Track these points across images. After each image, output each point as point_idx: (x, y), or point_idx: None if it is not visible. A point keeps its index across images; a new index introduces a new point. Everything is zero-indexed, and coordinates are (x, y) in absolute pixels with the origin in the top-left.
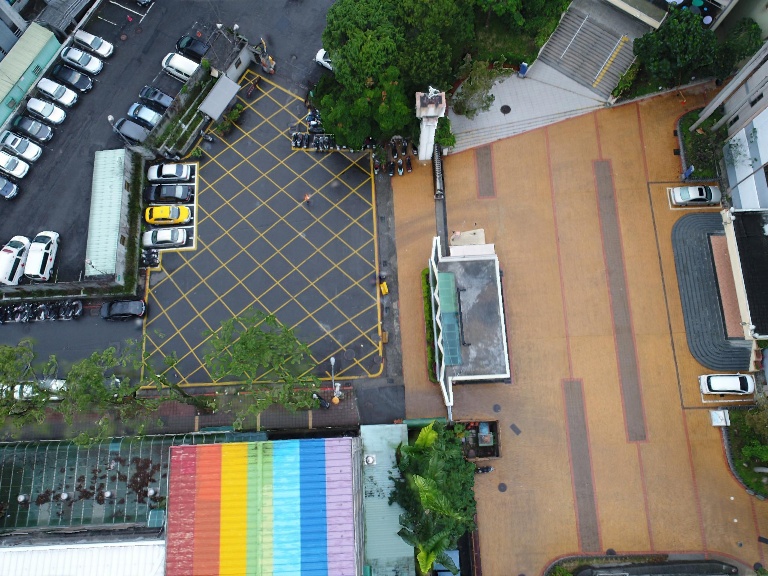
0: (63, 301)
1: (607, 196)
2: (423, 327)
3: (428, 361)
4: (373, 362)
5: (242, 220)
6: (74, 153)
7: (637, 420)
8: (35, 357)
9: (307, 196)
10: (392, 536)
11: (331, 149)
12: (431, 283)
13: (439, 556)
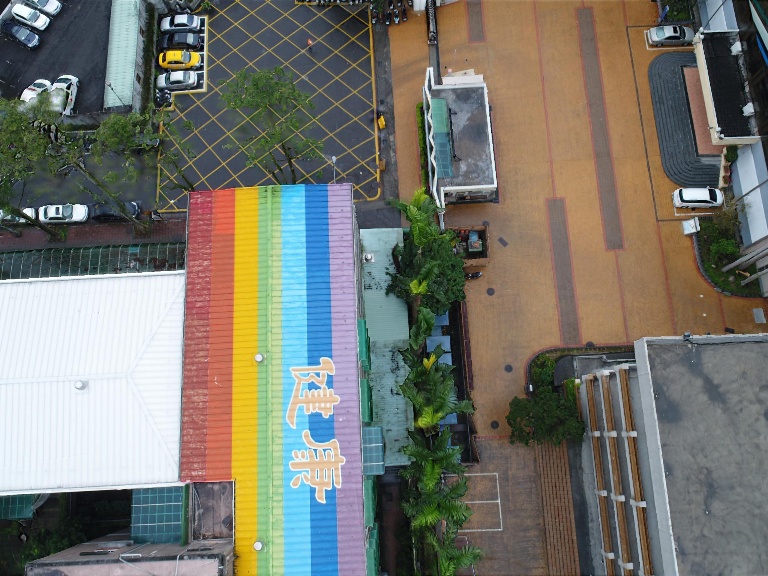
0: (83, 136)
1: (589, 39)
2: (418, 156)
3: (422, 182)
4: (371, 187)
5: (249, 65)
6: (91, 8)
7: (615, 232)
8: (58, 187)
9: (309, 40)
10: (389, 322)
11: (332, 2)
12: (425, 107)
13: (430, 287)
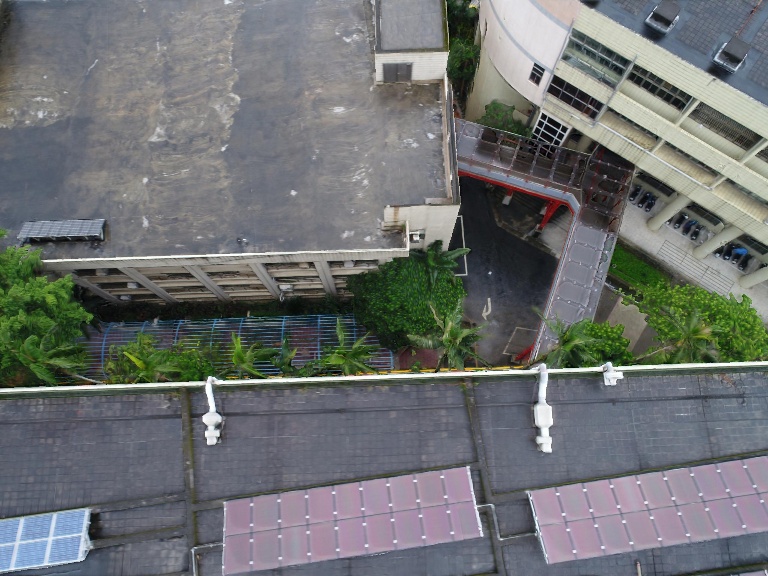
0: None
1: None
2: None
3: None
4: None
5: None
6: None
7: None
8: None
9: None
10: None
11: None
12: None
13: None
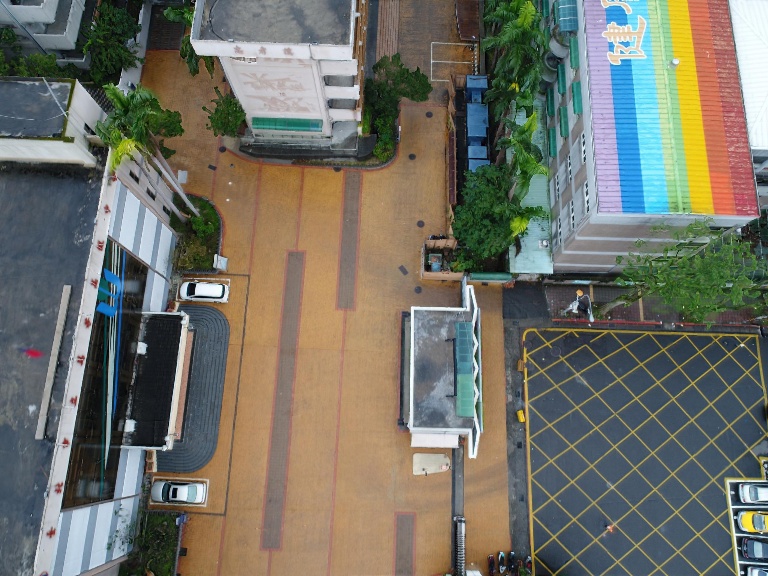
0: None
1: (274, 502)
2: (483, 373)
3: None
4: (533, 343)
5: (679, 510)
6: None
7: (293, 269)
8: None
9: (611, 529)
10: None
11: None
12: None
13: None
